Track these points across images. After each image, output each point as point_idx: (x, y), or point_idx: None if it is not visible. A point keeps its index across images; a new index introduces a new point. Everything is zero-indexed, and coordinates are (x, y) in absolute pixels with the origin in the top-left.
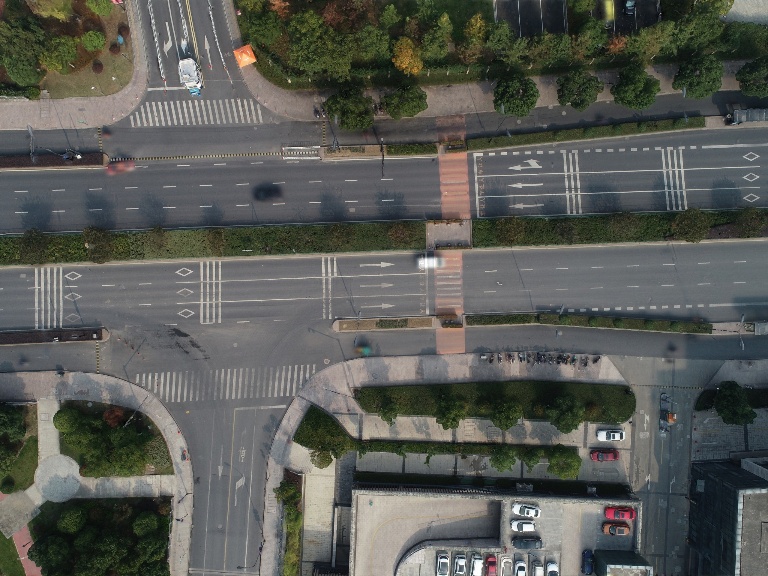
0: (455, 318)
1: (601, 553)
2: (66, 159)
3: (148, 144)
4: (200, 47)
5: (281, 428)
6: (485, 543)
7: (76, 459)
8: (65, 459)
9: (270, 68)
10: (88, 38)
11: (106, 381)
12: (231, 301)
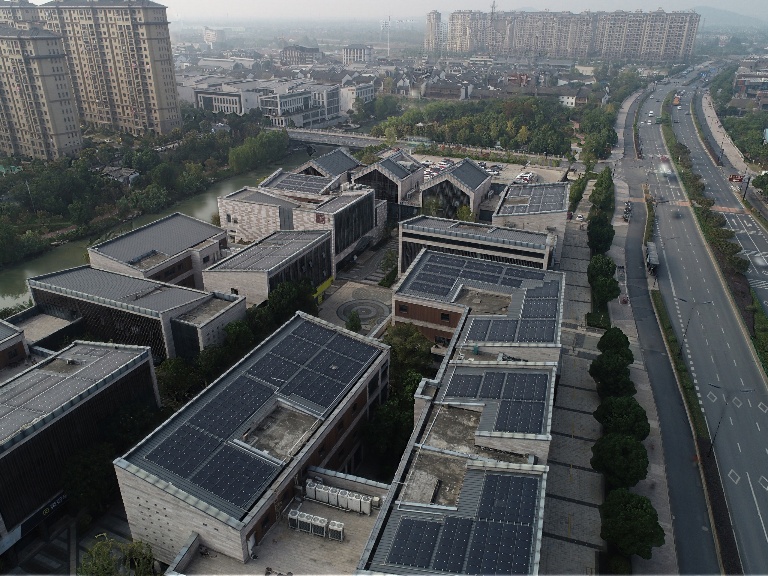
0: (650, 201)
1: None
2: None
3: None
4: None
5: None
6: None
7: None
8: None
9: None
10: None
11: None
12: None
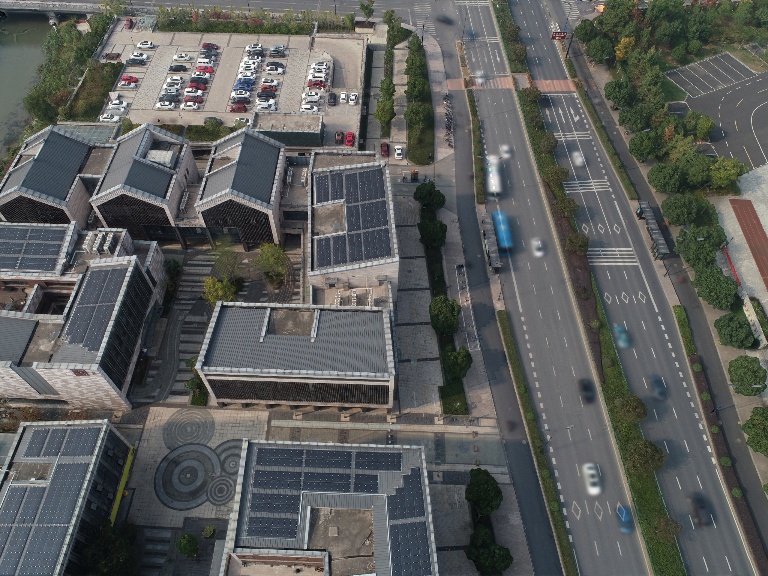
0: (470, 85)
1: None
2: None
3: None
4: (603, 1)
5: None
6: None
7: None
8: None
9: None
10: None
11: None
12: (468, 8)
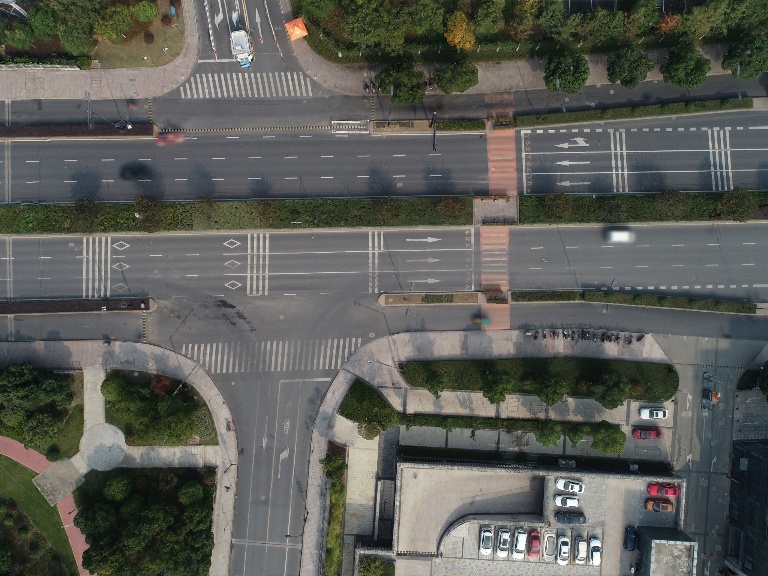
0: (500, 294)
1: (644, 529)
2: (116, 129)
3: (198, 116)
4: (251, 20)
5: (326, 401)
6: (528, 518)
7: (121, 428)
8: (110, 428)
9: (321, 42)
10: (142, 8)
11: (152, 351)
12: (278, 273)
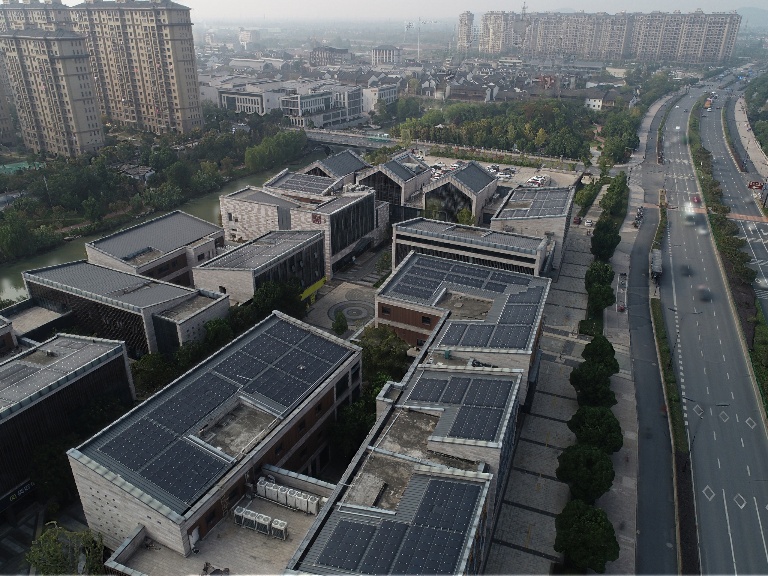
0: None
1: None
2: None
3: None
4: None
5: None
6: None
7: None
8: None
9: None
10: None
11: None
12: None
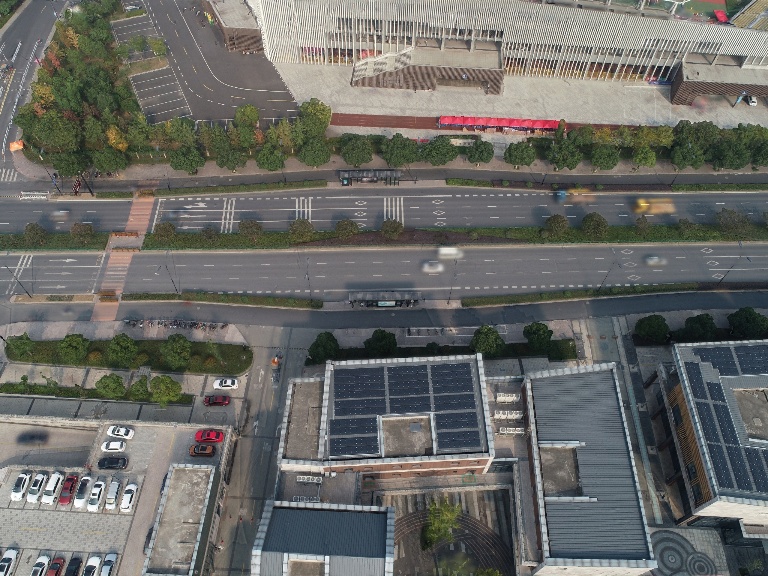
0: (113, 295)
1: None
2: None
3: None
4: None
5: None
6: None
7: None
8: None
9: (33, 153)
10: None
11: None
12: None
